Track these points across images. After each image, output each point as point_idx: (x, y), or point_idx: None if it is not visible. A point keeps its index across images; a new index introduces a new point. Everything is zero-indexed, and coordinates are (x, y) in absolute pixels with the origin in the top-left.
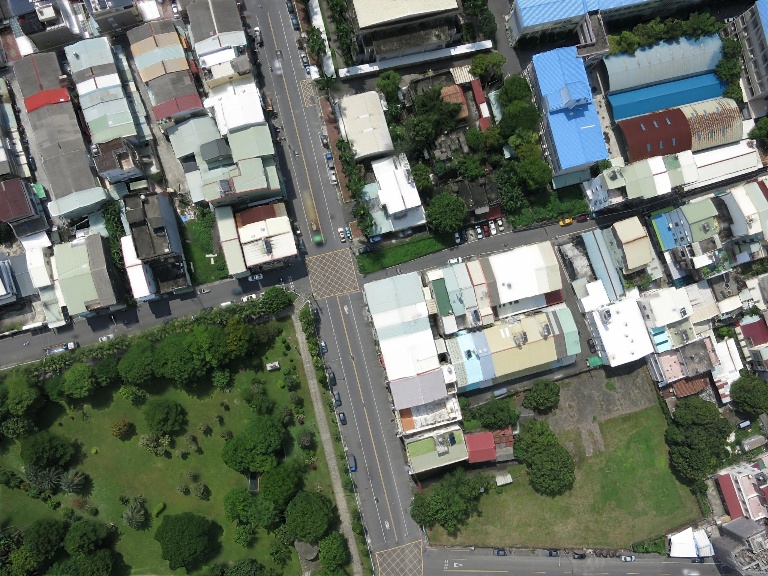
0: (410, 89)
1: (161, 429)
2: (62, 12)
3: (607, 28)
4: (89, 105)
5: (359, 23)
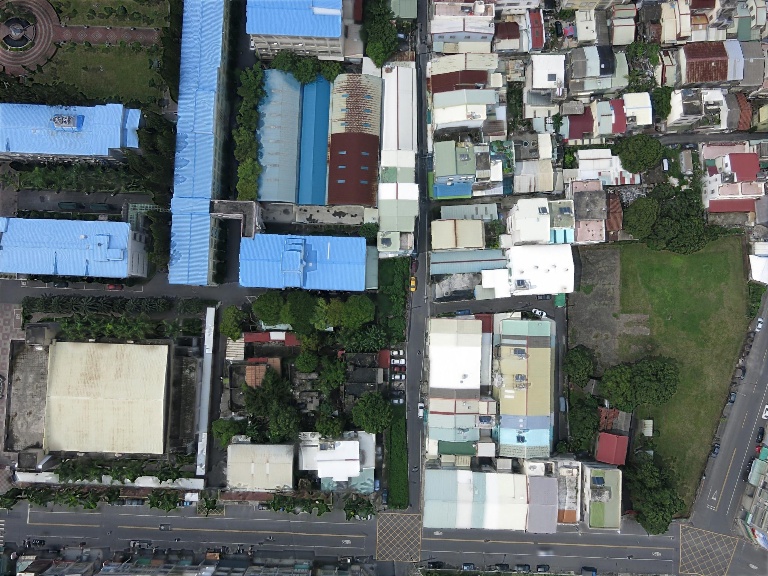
0: None
1: None
2: None
3: (227, 181)
4: None
5: (158, 453)
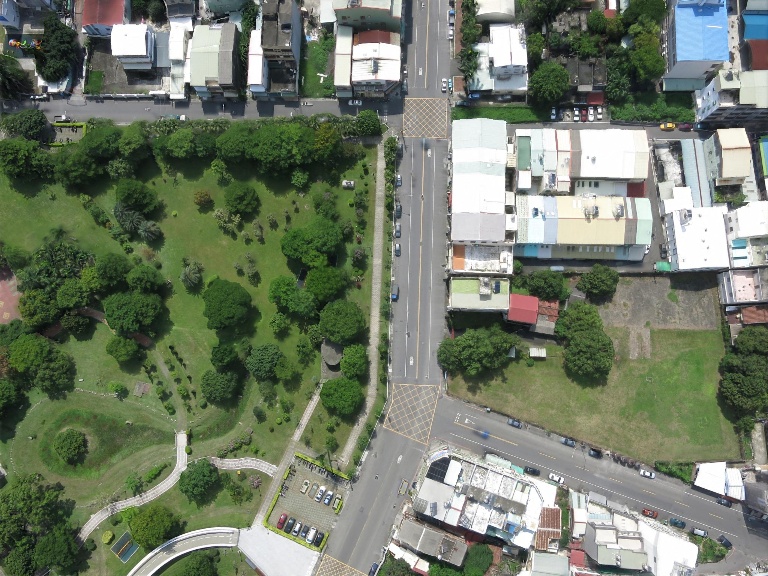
0: None
1: (236, 206)
2: None
3: None
4: None
5: None
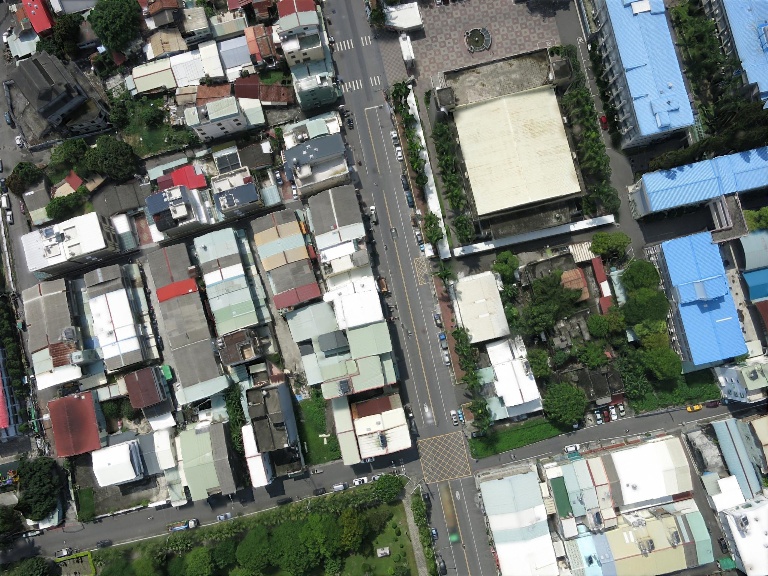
0: (528, 272)
1: None
2: (193, 206)
3: (742, 198)
4: (215, 295)
5: (478, 210)
